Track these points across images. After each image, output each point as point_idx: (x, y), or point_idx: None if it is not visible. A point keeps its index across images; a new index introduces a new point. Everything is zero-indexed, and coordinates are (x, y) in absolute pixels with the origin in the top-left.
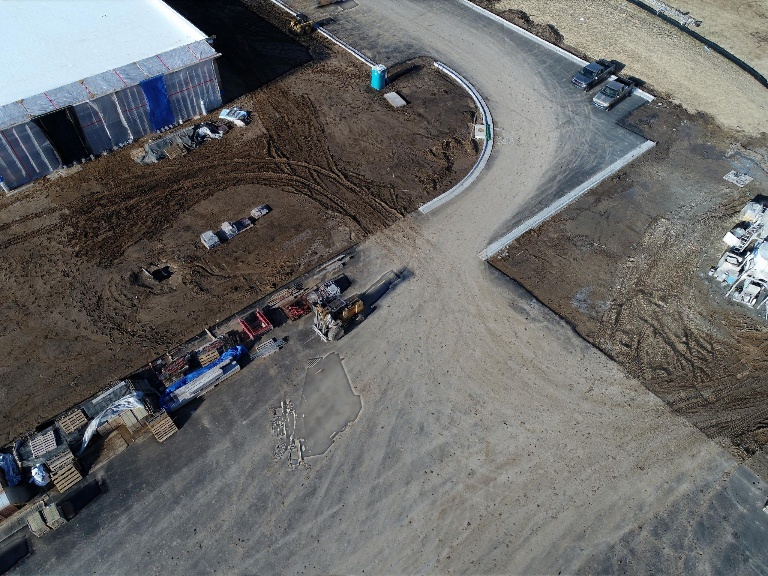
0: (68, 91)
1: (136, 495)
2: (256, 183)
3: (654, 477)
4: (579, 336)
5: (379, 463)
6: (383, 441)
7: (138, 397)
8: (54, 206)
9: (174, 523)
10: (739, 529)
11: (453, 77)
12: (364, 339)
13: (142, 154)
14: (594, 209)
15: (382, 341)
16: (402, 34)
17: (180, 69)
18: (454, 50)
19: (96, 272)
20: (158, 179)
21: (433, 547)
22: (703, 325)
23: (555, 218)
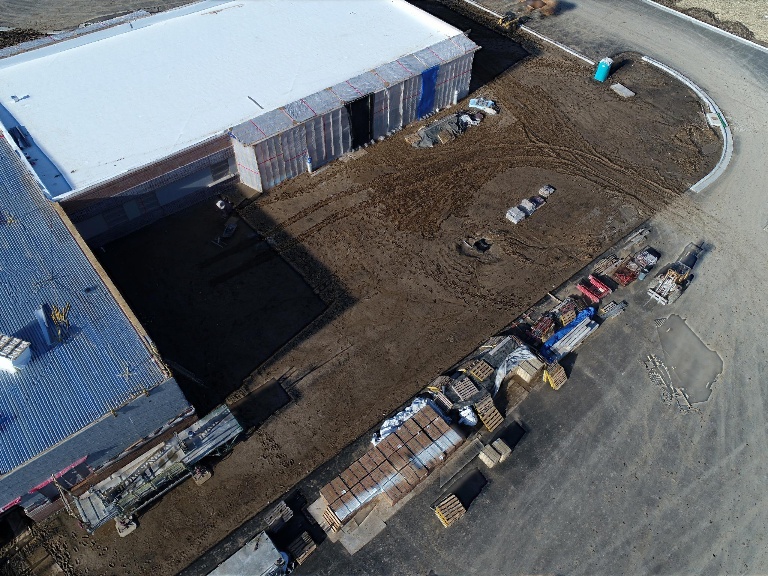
0: (366, 80)
1: (557, 434)
2: (530, 165)
3: None
4: None
5: (762, 409)
6: (756, 390)
7: (528, 350)
8: (359, 185)
9: (603, 458)
10: None
11: (665, 70)
12: (696, 303)
13: (418, 139)
14: None
15: (713, 304)
16: (600, 31)
17: (451, 60)
18: (655, 45)
19: (424, 243)
20: (439, 162)
21: None
22: None
23: None
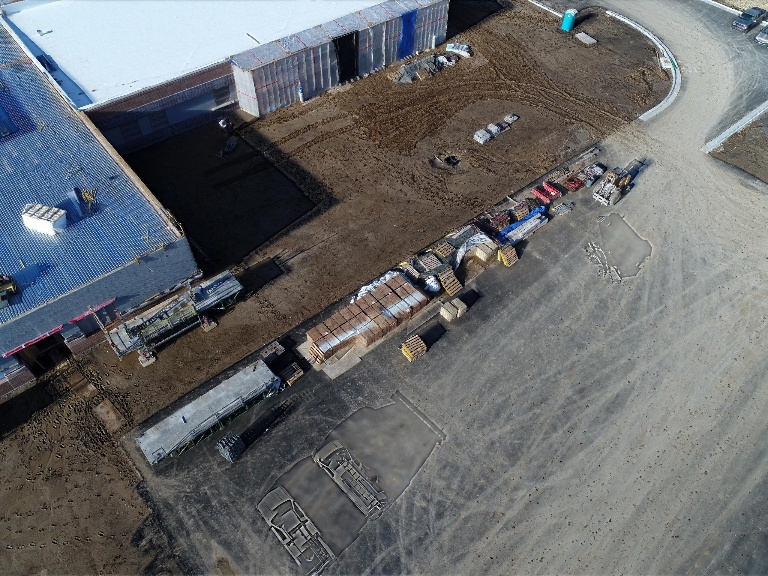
0: (351, 20)
1: (507, 299)
2: (498, 98)
3: None
4: None
5: (681, 281)
6: (678, 268)
7: (486, 235)
8: (345, 112)
9: (544, 315)
10: None
11: (626, 22)
12: (634, 204)
13: (399, 76)
14: None
15: (649, 206)
16: None
17: (429, 5)
18: (619, 1)
19: (401, 158)
20: (417, 95)
21: (744, 331)
22: None
23: (753, 125)
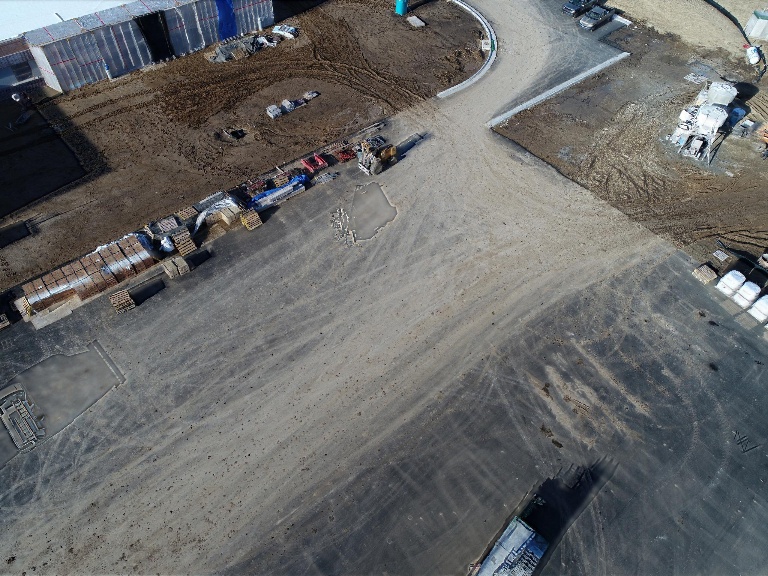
0: None
1: (237, 259)
2: (306, 77)
3: (613, 255)
4: (562, 175)
5: (411, 244)
6: (414, 232)
7: (233, 200)
8: (149, 89)
9: (266, 274)
10: (673, 284)
11: (463, 7)
12: (397, 174)
13: (214, 55)
14: (577, 97)
15: (411, 176)
16: None
17: None
18: None
19: (188, 131)
20: (228, 73)
21: (452, 289)
22: (658, 170)
23: (546, 102)
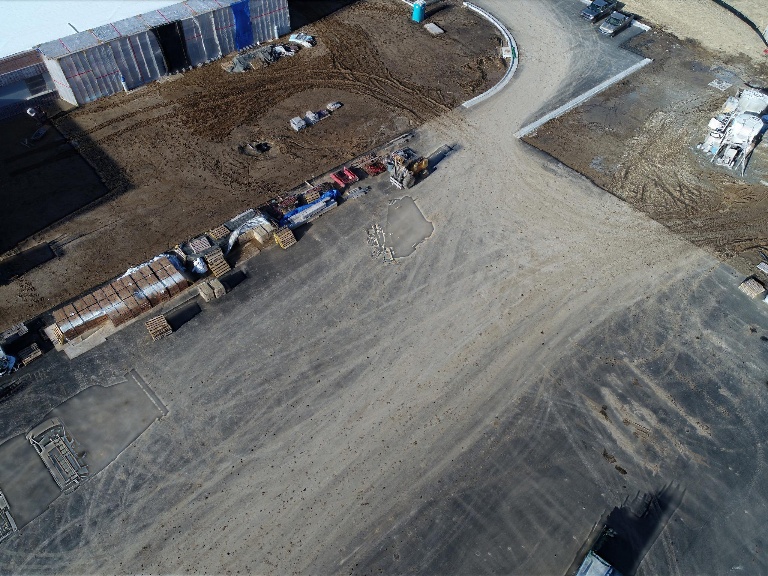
0: (176, 9)
1: (273, 279)
2: (327, 87)
3: (658, 269)
4: (597, 186)
5: (452, 261)
6: (453, 248)
7: (265, 218)
8: (167, 101)
9: (305, 295)
10: (721, 299)
11: (480, 13)
12: (430, 188)
13: (232, 65)
14: (604, 105)
15: (444, 189)
16: None
17: None
18: None
19: (211, 145)
20: (247, 84)
21: (497, 308)
22: (693, 180)
23: (573, 111)
